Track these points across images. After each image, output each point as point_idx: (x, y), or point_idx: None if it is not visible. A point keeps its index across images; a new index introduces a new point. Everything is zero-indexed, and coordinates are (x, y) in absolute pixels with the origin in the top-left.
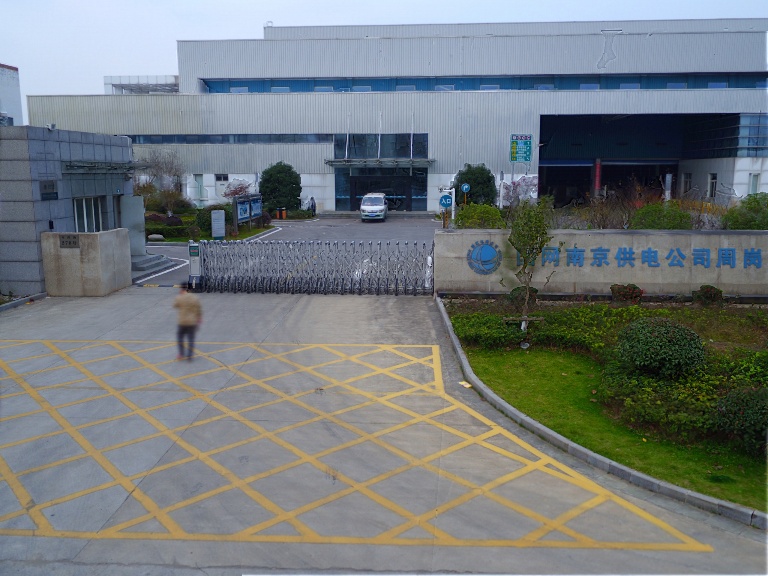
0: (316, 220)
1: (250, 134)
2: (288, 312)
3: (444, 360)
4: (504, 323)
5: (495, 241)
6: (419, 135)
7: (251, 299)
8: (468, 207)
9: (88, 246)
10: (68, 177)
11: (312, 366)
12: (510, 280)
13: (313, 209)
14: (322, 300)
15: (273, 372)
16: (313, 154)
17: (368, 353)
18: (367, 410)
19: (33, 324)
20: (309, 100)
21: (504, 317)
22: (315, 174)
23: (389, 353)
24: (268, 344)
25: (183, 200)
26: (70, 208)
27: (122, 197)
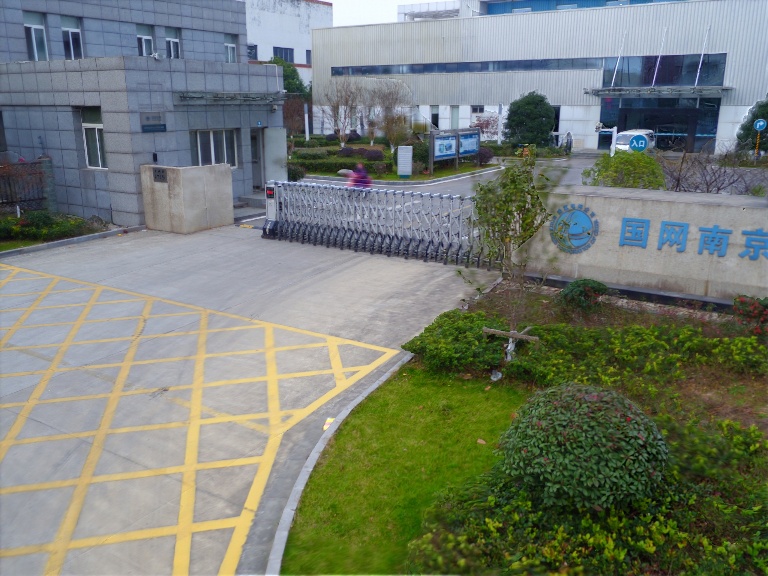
0: (563, 160)
1: (510, 60)
2: (313, 275)
3: (369, 376)
4: (484, 336)
5: (592, 206)
6: (714, 56)
7: (304, 253)
8: (761, 150)
9: (173, 181)
10: (184, 108)
11: (213, 353)
12: (606, 265)
13: (568, 147)
14: (373, 263)
15: (163, 354)
16: (578, 82)
17: (300, 347)
18: (154, 435)
19: (84, 258)
20: (579, 18)
21: (484, 327)
22: (578, 106)
23: (322, 351)
24: (223, 314)
25: (407, 133)
26: (186, 141)
27: (266, 130)
